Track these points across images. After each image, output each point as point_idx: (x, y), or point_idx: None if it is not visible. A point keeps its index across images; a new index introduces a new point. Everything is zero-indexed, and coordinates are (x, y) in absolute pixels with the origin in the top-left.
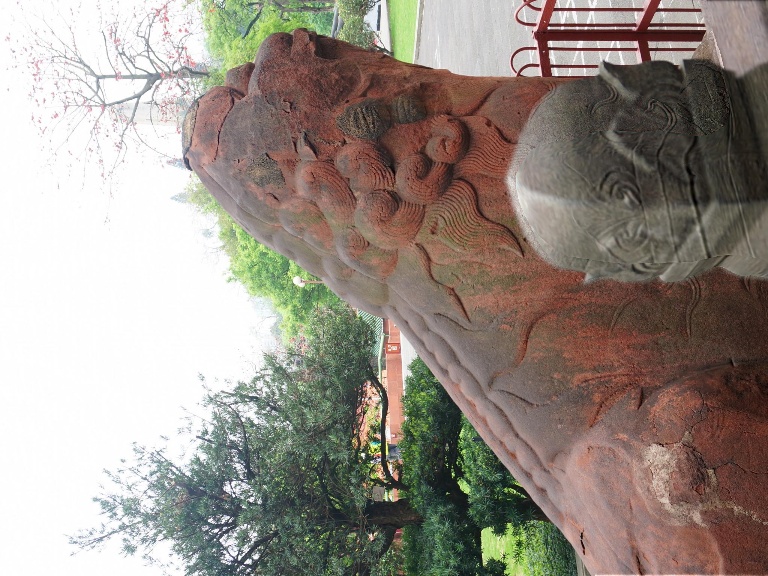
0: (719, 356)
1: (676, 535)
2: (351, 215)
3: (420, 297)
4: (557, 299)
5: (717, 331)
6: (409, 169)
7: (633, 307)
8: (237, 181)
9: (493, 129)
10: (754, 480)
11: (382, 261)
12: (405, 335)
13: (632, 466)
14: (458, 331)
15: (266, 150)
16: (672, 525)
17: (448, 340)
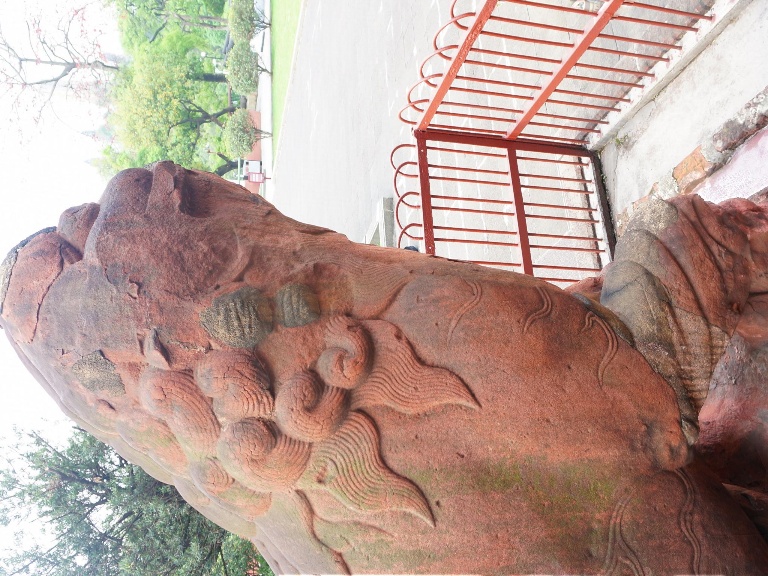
0: None
1: None
2: (212, 444)
3: (297, 553)
4: None
5: None
6: (294, 396)
7: None
8: (60, 376)
9: (404, 344)
10: None
11: (250, 504)
12: None
13: None
14: None
15: (100, 346)
16: None
17: None
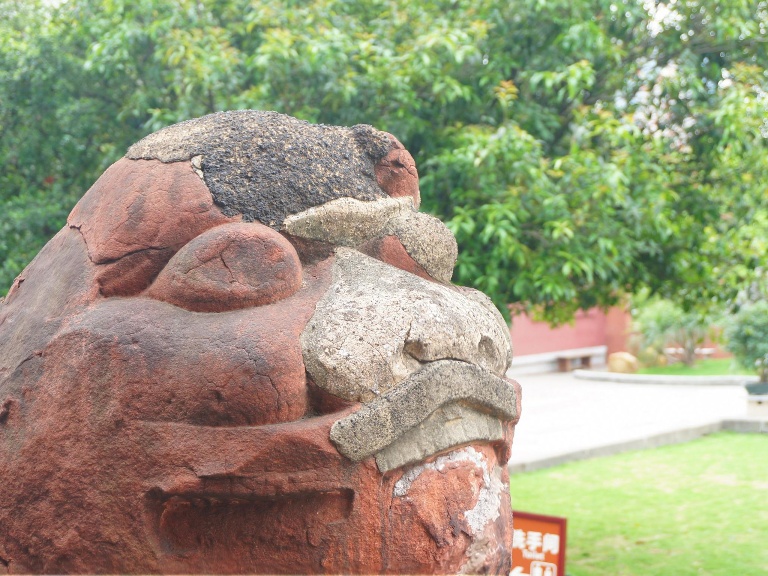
0: None
1: None
2: None
3: None
4: None
5: None
6: None
7: None
8: None
9: None
10: None
11: None
12: None
13: None
14: None
15: None
16: None
17: None
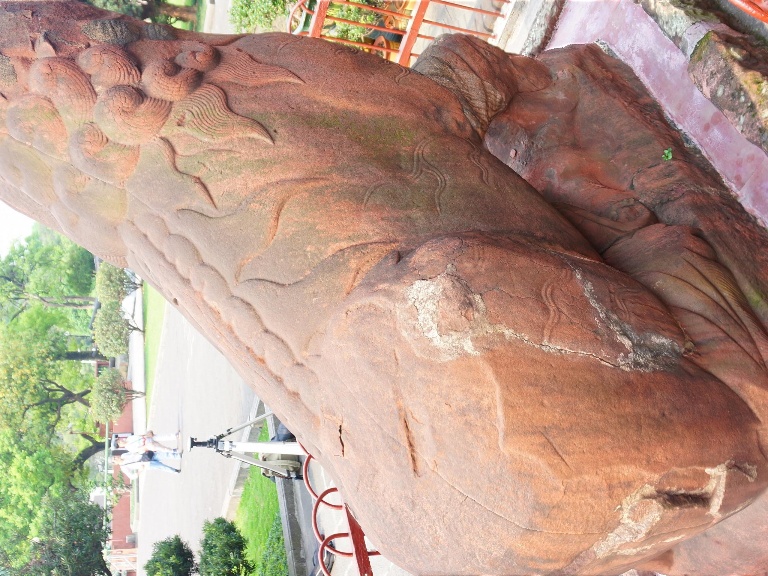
0: (469, 228)
1: (447, 372)
2: (90, 110)
3: (162, 193)
4: (309, 179)
5: (465, 209)
6: (157, 67)
7: (384, 188)
8: None
9: (244, 52)
10: (521, 304)
11: (121, 157)
12: (143, 254)
13: (395, 311)
14: (203, 221)
15: None
16: (442, 362)
17: (191, 236)
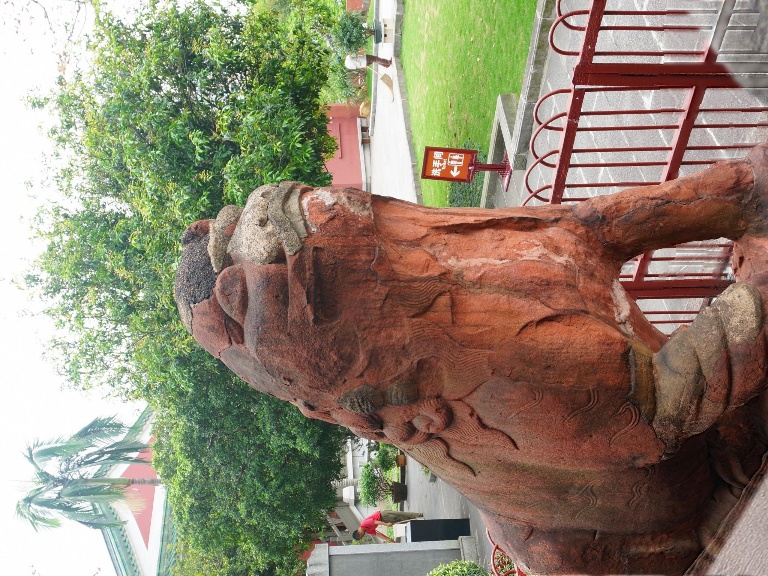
0: (590, 528)
1: None
2: None
3: None
4: (493, 494)
5: None
6: (395, 436)
7: (544, 505)
8: None
9: (474, 420)
10: None
11: None
12: None
13: None
14: None
15: None
16: None
17: None
